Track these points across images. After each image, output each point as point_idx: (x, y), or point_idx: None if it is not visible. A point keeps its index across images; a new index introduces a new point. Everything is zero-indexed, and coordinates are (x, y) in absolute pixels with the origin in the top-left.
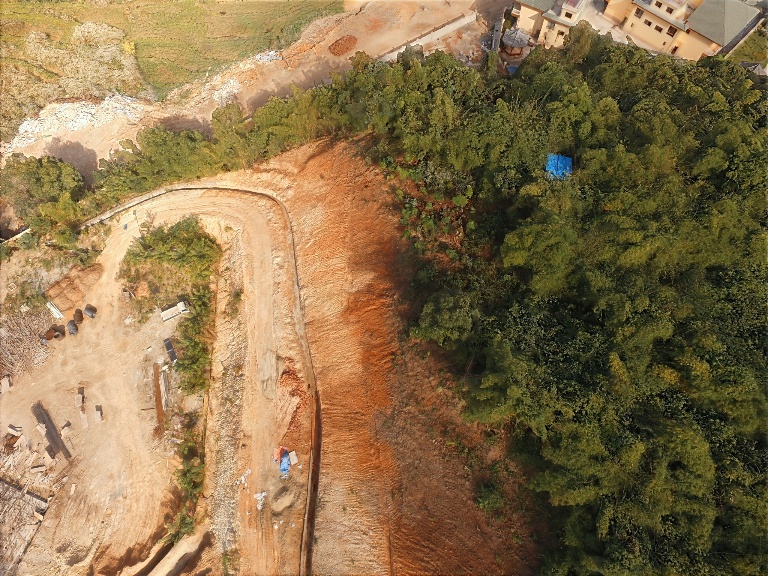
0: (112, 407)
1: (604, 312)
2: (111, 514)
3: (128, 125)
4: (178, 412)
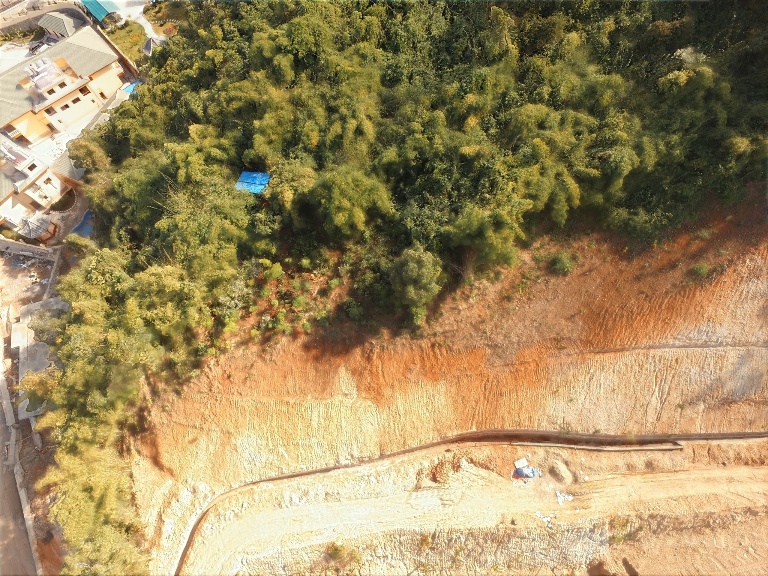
0: None
1: (416, 157)
2: None
3: None
4: None
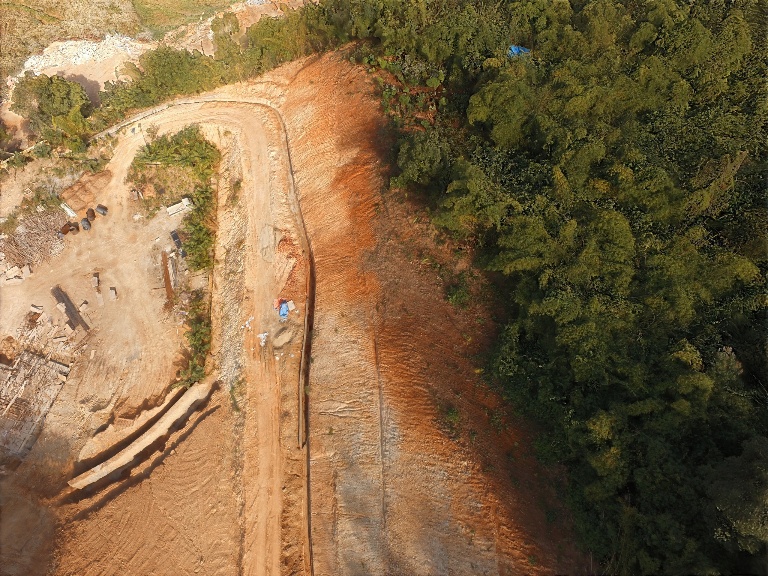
0: (125, 288)
1: (551, 147)
2: (128, 373)
3: (128, 60)
4: (185, 290)
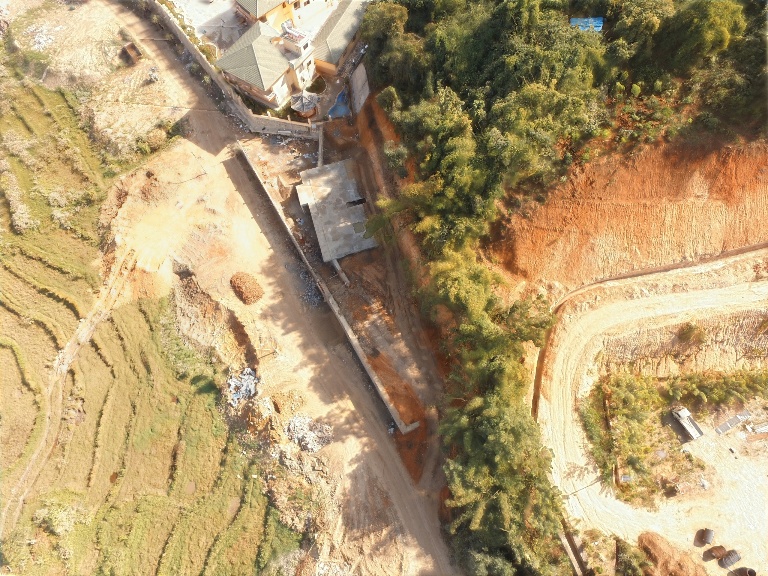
0: None
1: None
2: None
3: None
4: None
